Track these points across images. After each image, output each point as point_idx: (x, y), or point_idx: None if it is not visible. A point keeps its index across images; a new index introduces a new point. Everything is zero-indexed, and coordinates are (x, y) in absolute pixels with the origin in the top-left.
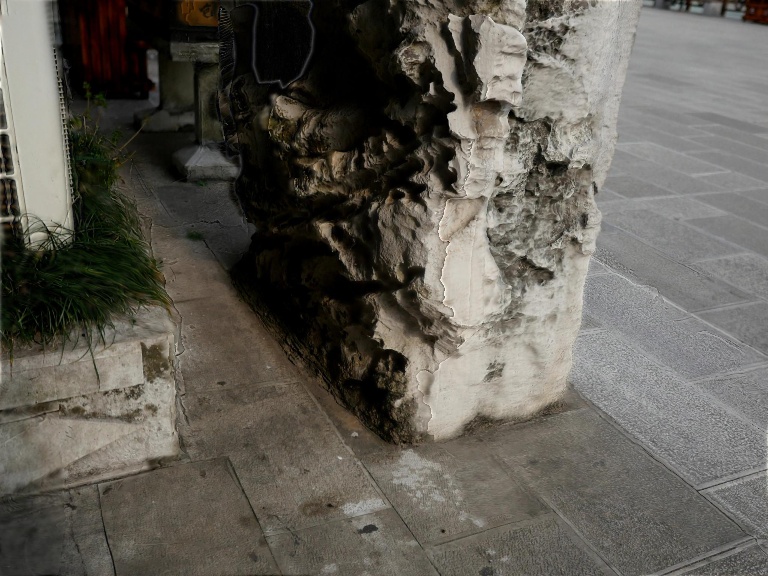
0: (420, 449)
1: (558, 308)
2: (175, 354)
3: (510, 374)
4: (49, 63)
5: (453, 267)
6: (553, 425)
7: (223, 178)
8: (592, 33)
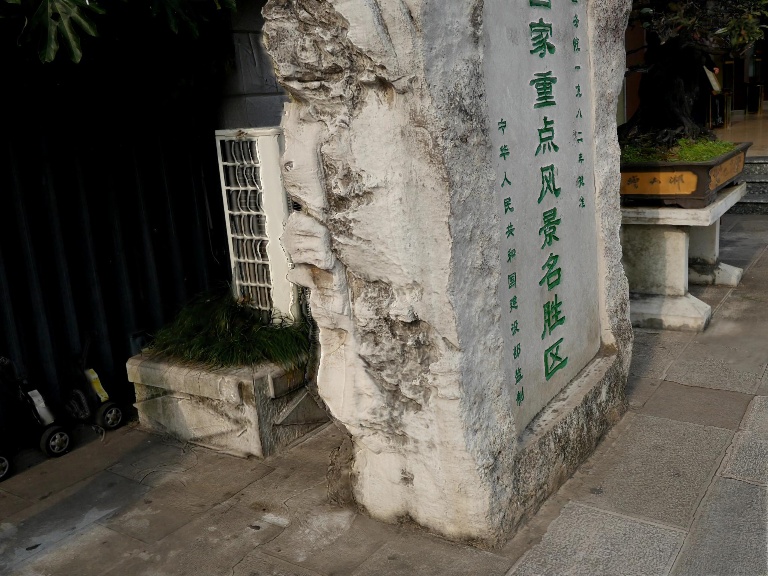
0: (338, 509)
1: (434, 439)
2: (272, 398)
3: (421, 487)
4: (281, 229)
5: (332, 375)
6: (462, 553)
7: None
8: (374, 223)
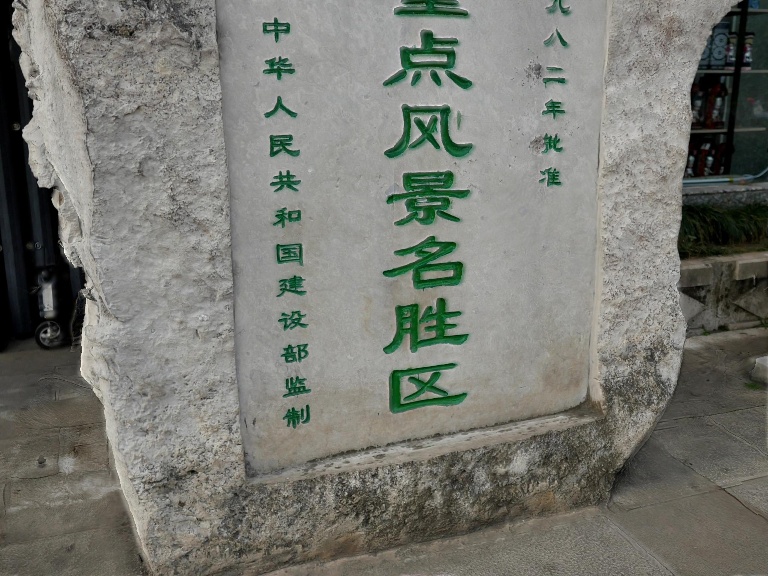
0: (104, 473)
1: None
2: None
3: None
4: None
5: (86, 318)
6: None
7: None
8: None
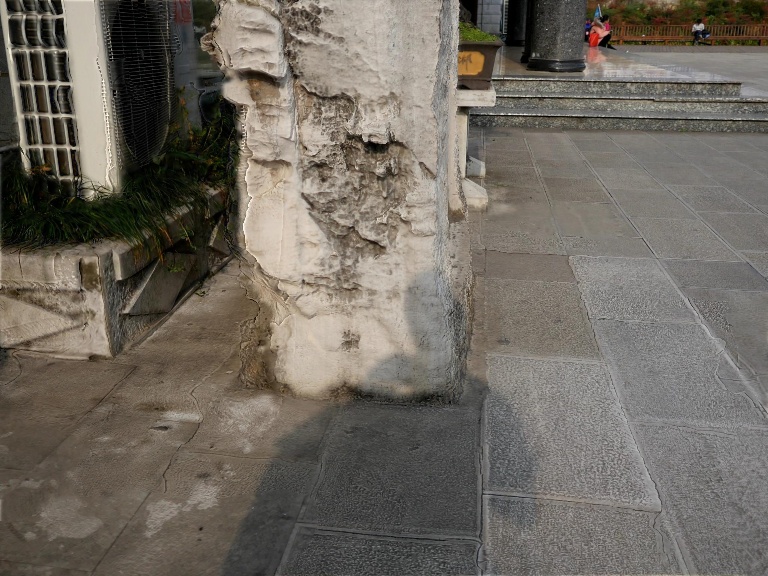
0: (260, 391)
1: (398, 286)
2: (118, 279)
3: (369, 348)
4: (94, 68)
5: (264, 222)
6: (421, 414)
7: None
8: (353, 12)
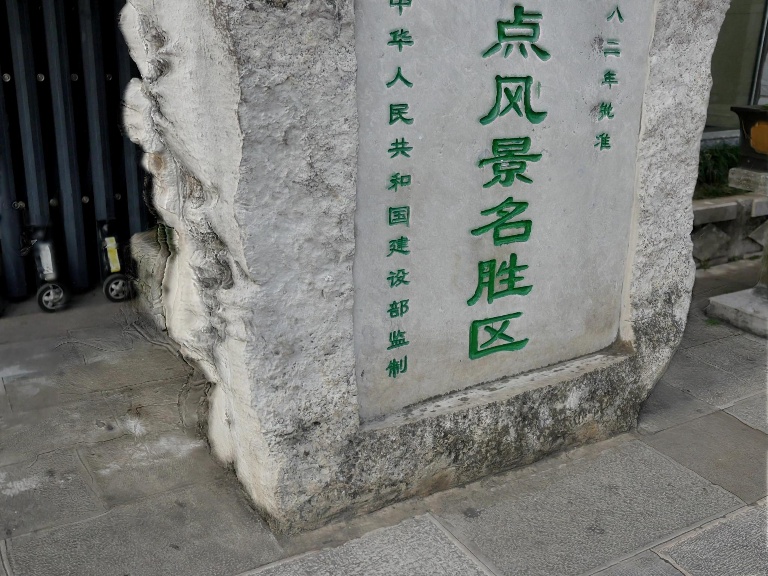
0: (178, 432)
1: None
2: None
3: None
4: None
5: (171, 281)
6: (247, 525)
7: (738, 324)
8: None
